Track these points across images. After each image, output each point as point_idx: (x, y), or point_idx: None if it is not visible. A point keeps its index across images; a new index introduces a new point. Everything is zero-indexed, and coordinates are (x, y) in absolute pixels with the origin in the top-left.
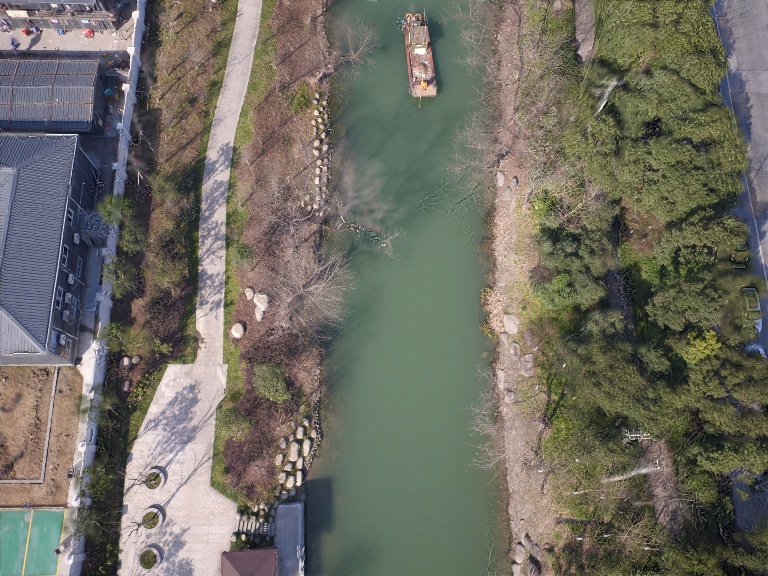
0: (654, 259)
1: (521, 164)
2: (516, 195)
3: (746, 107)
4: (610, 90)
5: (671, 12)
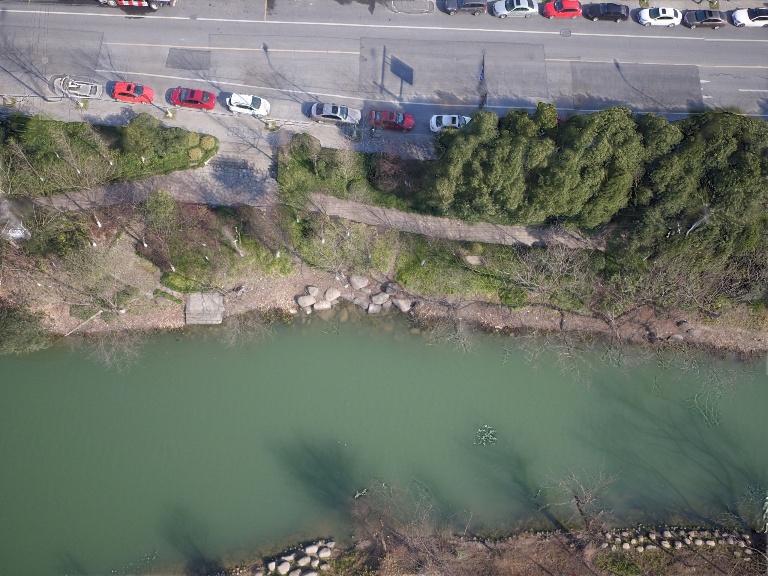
0: (764, 204)
1: (668, 316)
2: (698, 324)
3: (589, 99)
4: (654, 220)
5: (607, 149)
